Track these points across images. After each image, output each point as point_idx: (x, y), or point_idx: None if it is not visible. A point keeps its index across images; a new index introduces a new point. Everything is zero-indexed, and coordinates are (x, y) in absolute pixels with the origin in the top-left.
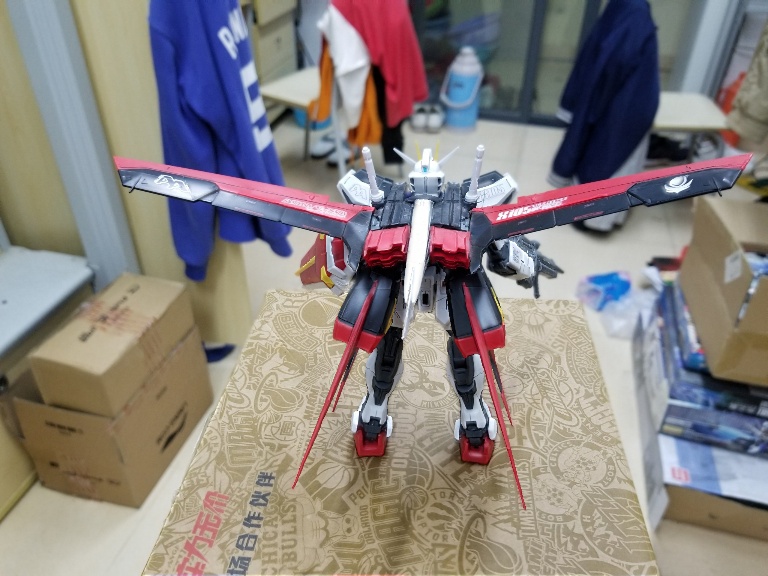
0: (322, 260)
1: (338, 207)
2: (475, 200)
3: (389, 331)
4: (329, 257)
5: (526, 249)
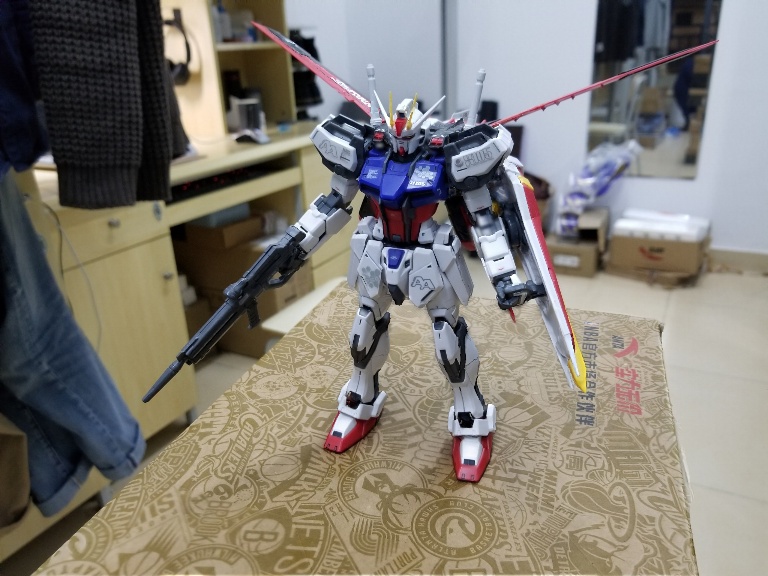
0: None
1: None
2: None
3: None
4: None
5: None
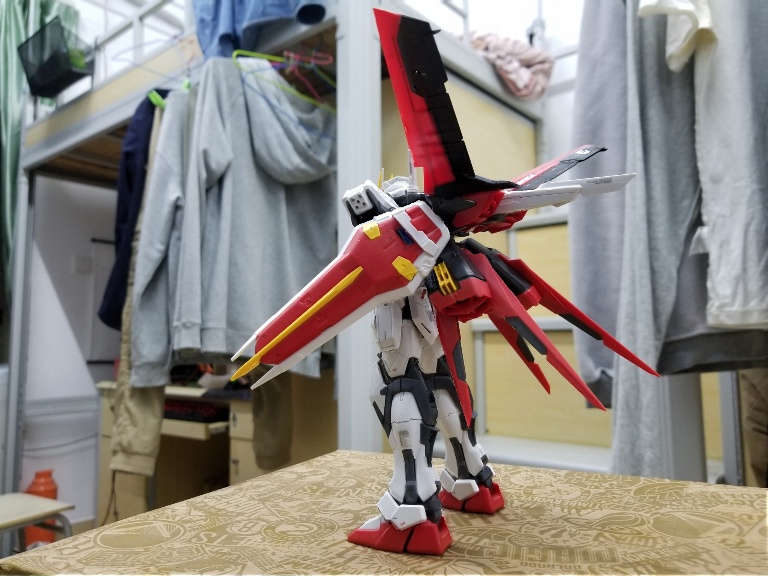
0: (391, 253)
1: None
2: None
3: (413, 364)
4: (418, 233)
5: None
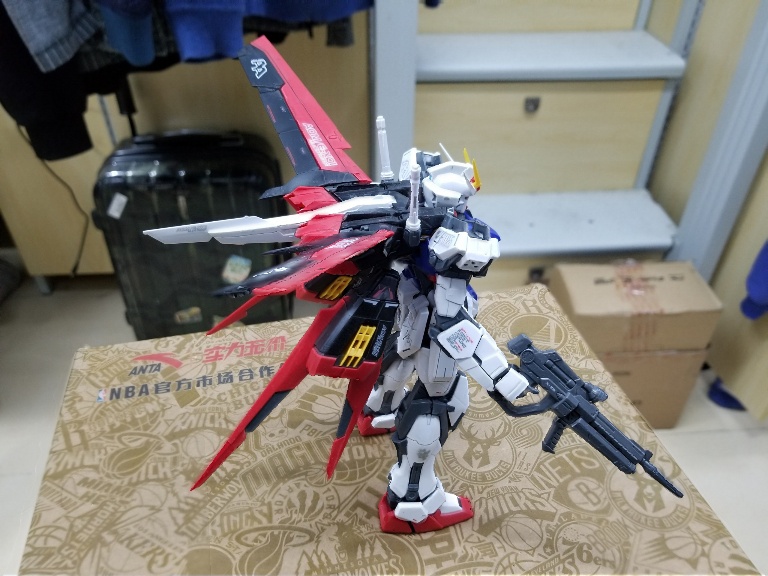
0: None
1: (339, 157)
2: (410, 228)
3: None
4: None
5: (547, 375)
